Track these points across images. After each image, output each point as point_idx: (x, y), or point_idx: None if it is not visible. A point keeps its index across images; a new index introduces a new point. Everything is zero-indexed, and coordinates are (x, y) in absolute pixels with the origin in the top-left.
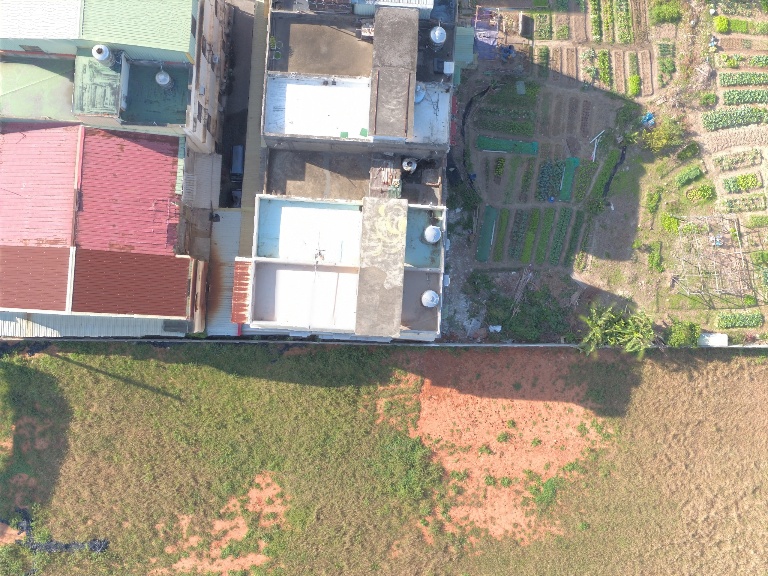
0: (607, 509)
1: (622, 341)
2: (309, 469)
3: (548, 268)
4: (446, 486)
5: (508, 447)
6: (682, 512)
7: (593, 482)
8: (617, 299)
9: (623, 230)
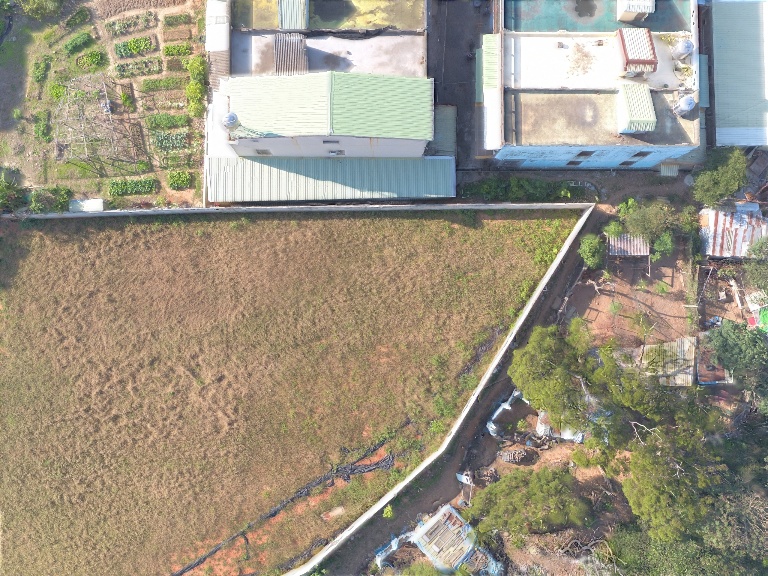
0: None
1: None
2: None
3: None
4: None
5: None
6: (73, 387)
7: None
8: (4, 172)
9: (10, 101)
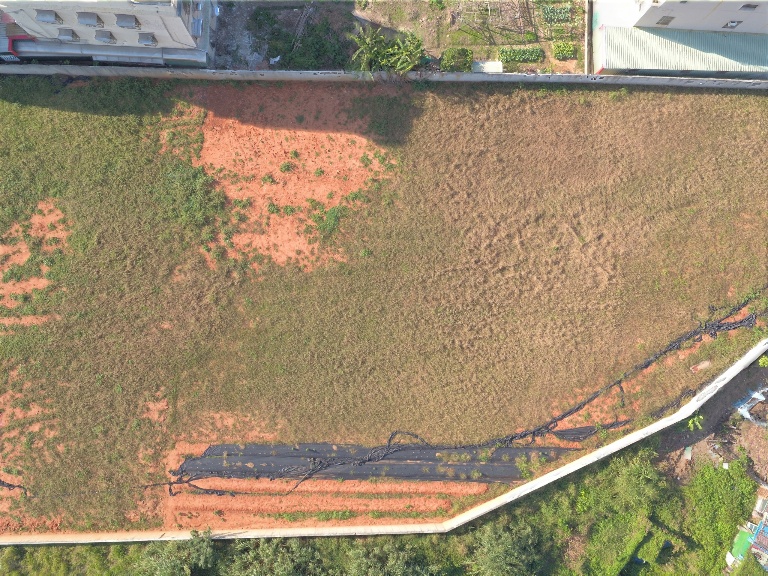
0: (389, 236)
1: (392, 61)
2: (90, 194)
3: (330, 6)
4: (229, 214)
5: (291, 177)
6: (464, 239)
7: (376, 210)
8: (398, 36)
9: None
